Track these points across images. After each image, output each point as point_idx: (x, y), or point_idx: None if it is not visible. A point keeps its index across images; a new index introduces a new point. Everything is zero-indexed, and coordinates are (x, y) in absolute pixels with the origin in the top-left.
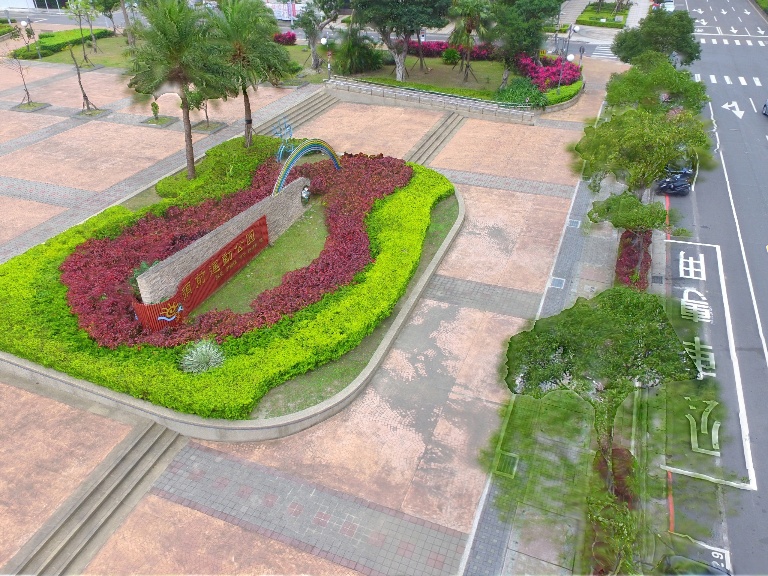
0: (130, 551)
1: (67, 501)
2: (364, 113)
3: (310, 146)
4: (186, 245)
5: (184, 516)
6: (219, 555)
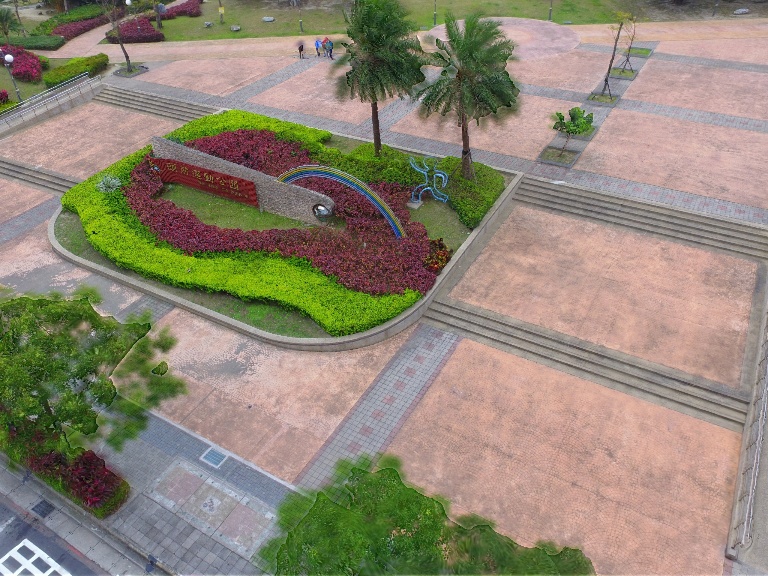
0: (27, 195)
1: (64, 174)
2: (694, 281)
3: (343, 178)
4: (238, 161)
5: (32, 205)
6: (0, 215)
